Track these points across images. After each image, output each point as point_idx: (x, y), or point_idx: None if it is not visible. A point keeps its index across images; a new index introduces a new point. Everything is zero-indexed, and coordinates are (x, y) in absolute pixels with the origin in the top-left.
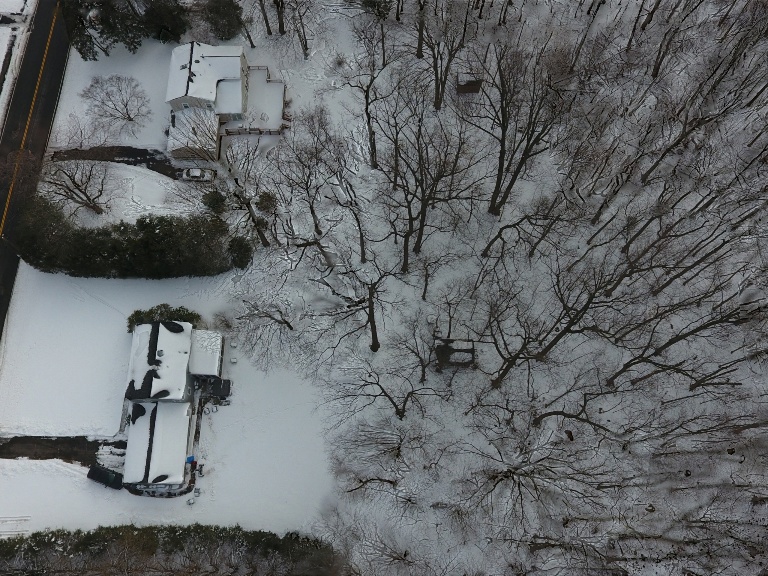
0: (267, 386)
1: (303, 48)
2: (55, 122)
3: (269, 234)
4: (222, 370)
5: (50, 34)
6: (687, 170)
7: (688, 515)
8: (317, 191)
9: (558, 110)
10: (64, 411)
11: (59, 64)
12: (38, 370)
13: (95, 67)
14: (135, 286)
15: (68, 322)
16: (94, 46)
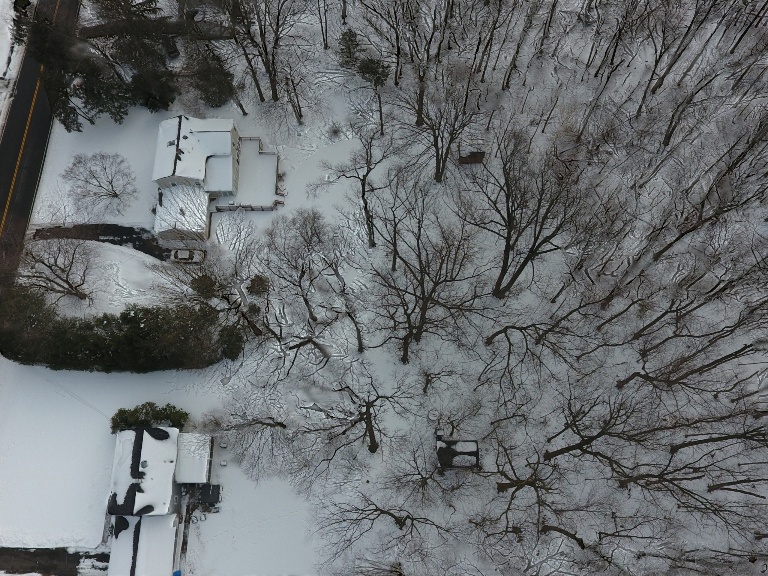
0: (258, 495)
1: (297, 117)
2: (37, 197)
3: (261, 324)
4: (211, 473)
5: (34, 99)
6: (701, 247)
7: None
8: (311, 283)
9: (565, 182)
10: (43, 519)
11: (42, 133)
12: (16, 473)
13: (80, 137)
14: (120, 379)
15: (49, 419)
16: (78, 118)
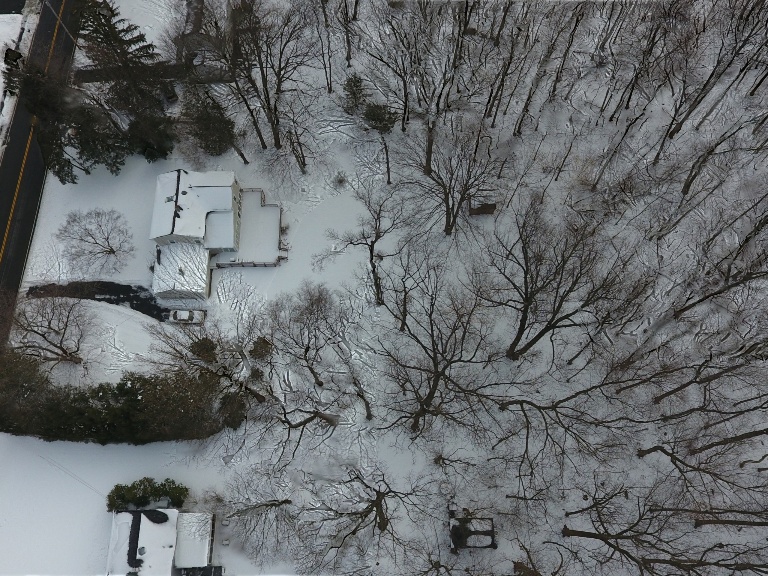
0: None
1: (301, 166)
2: (31, 252)
3: (264, 392)
4: (213, 554)
5: (27, 147)
6: (724, 302)
7: None
8: (317, 353)
9: (580, 234)
10: None
11: (36, 183)
12: (8, 553)
13: (75, 187)
14: (116, 450)
15: (42, 494)
16: (73, 170)
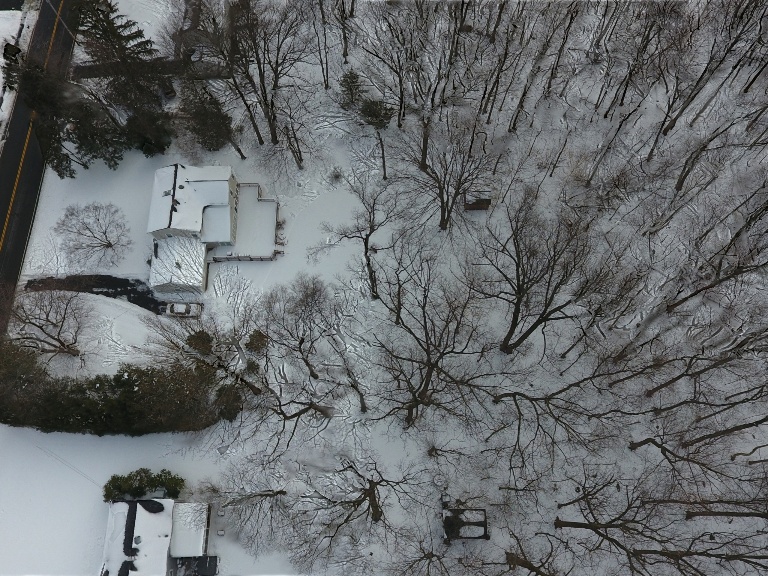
0: (257, 569)
1: (297, 162)
2: (29, 245)
3: (260, 384)
4: (208, 544)
5: (26, 142)
6: (716, 297)
7: None
8: (312, 345)
9: (574, 229)
10: None
11: (35, 177)
12: (5, 543)
13: (73, 182)
14: (113, 441)
15: (39, 485)
16: (71, 164)
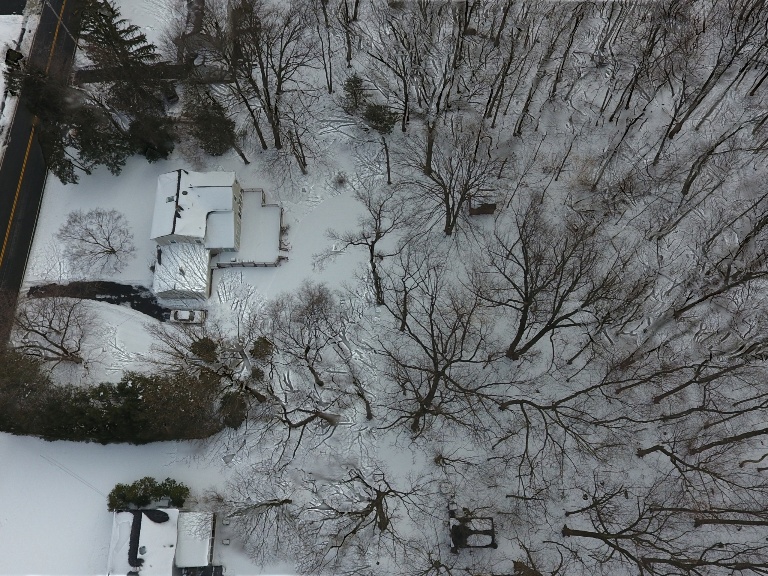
0: None
1: (301, 166)
2: (32, 252)
3: (265, 392)
4: (213, 553)
5: (28, 147)
6: (724, 302)
7: None
8: (317, 353)
9: (580, 234)
10: None
11: (37, 183)
12: (9, 553)
13: (76, 187)
14: (117, 450)
15: (43, 494)
16: (73, 170)
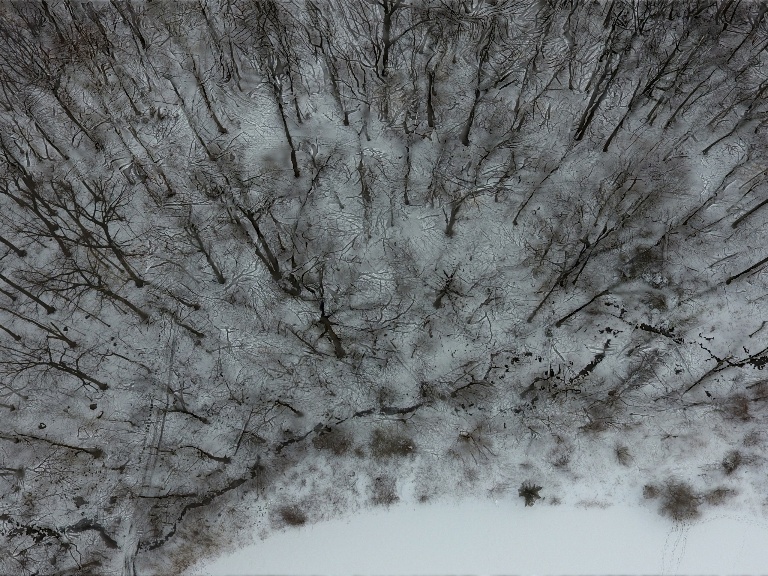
0: None
1: None
2: None
3: None
4: None
5: None
6: (147, 138)
7: (13, 464)
8: None
9: None
10: None
11: None
12: None
13: None
14: None
15: None
16: None
